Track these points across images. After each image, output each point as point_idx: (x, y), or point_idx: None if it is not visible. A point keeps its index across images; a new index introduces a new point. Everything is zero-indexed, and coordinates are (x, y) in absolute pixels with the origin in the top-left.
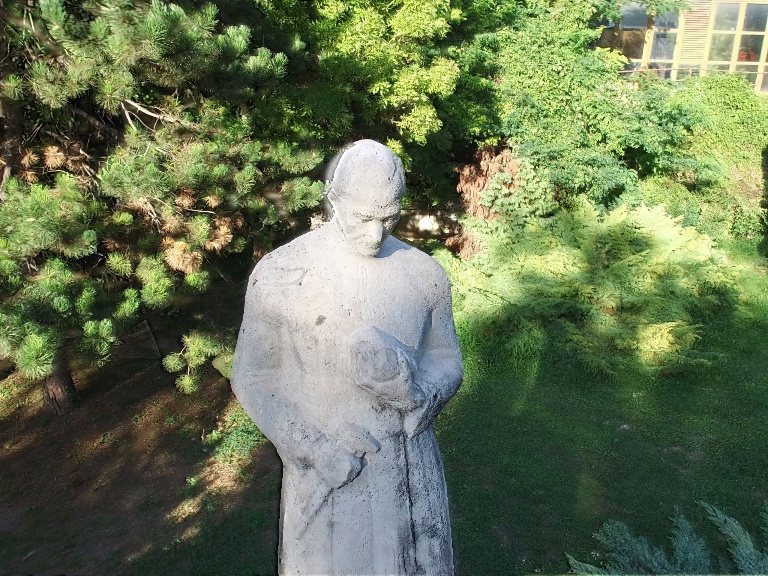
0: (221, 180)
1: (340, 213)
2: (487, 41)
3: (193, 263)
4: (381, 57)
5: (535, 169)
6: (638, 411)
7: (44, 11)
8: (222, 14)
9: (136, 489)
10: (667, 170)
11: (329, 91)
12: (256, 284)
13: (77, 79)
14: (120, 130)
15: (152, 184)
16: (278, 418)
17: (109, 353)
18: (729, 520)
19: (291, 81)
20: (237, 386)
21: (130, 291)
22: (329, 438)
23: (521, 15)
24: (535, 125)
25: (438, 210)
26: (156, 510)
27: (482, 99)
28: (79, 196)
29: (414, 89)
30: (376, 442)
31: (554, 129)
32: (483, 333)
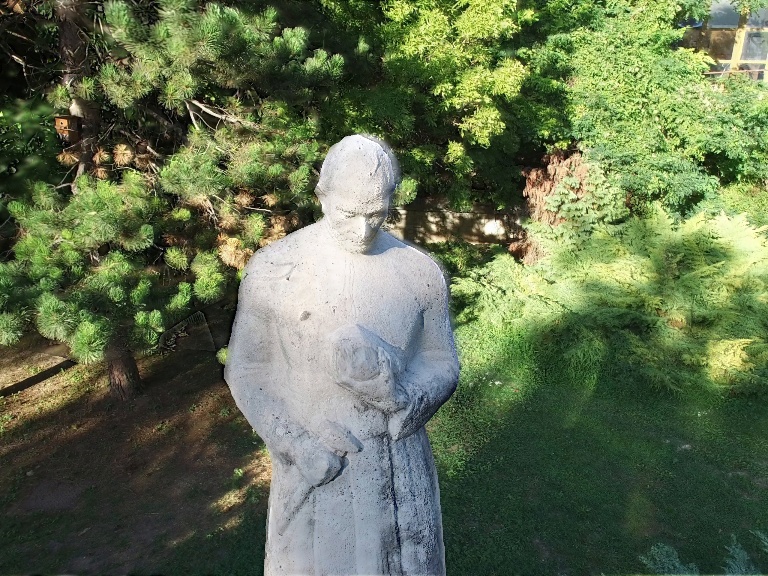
0: (275, 179)
1: (326, 209)
2: (560, 42)
3: (245, 259)
4: (443, 58)
5: (606, 174)
6: (703, 431)
7: (107, 15)
8: (283, 17)
9: (187, 476)
10: (753, 177)
11: (390, 93)
12: (246, 278)
13: (140, 80)
14: (184, 130)
15: (206, 181)
16: (263, 412)
17: (174, 344)
18: None
19: (353, 83)
20: (229, 378)
21: (184, 284)
22: (311, 435)
23: (598, 15)
24: (607, 128)
25: (504, 214)
26: (204, 497)
27: (552, 101)
28: (142, 192)
29: (476, 91)
30: (357, 442)
31: (628, 133)
32: (541, 341)
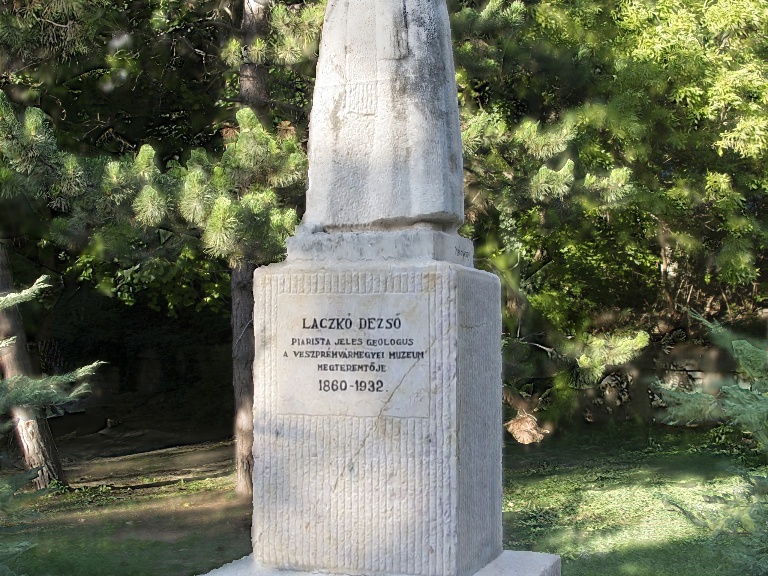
0: None
1: None
2: None
3: None
4: (685, 55)
5: None
6: None
7: None
8: None
9: None
10: None
11: (615, 100)
12: None
13: (309, 22)
14: None
15: None
16: None
17: None
18: None
19: (572, 100)
20: None
21: None
22: None
23: None
24: None
25: None
26: None
27: None
28: None
29: (734, 93)
30: None
31: None
32: None
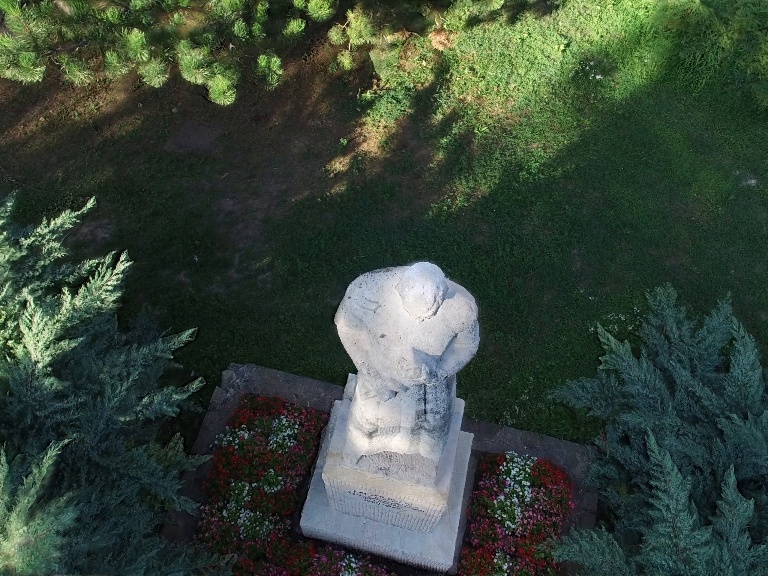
0: None
1: (401, 298)
2: None
3: None
4: None
5: None
6: None
7: None
8: None
9: (301, 136)
10: None
11: None
12: (350, 300)
13: None
14: None
15: None
16: (356, 357)
17: None
18: (747, 338)
19: None
20: None
21: (298, 1)
22: (382, 377)
23: None
24: None
25: None
26: (315, 161)
27: None
28: None
29: None
30: (406, 388)
31: None
32: (666, 25)
